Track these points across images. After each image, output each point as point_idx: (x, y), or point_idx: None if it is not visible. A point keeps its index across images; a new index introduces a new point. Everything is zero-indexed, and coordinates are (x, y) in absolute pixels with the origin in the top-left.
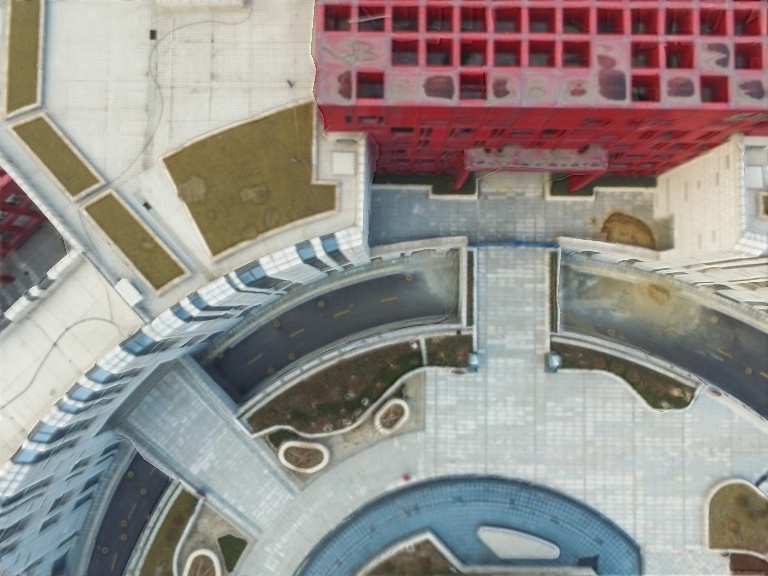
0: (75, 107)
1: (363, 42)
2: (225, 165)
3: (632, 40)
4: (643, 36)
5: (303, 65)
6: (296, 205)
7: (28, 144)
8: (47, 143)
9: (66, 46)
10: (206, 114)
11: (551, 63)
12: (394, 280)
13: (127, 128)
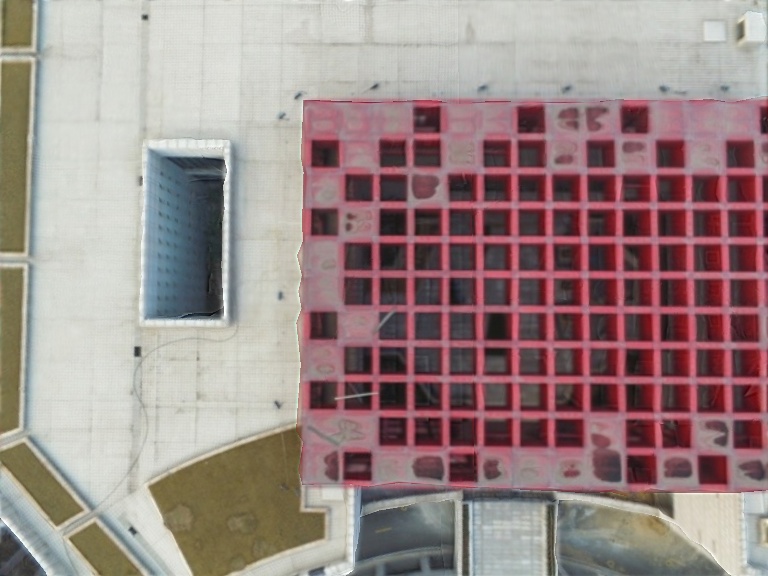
0: (58, 428)
1: (350, 420)
2: (212, 493)
3: (627, 418)
4: (638, 413)
5: (291, 385)
6: (284, 535)
7: (11, 470)
8: (30, 470)
9: (49, 364)
10: (192, 435)
11: (544, 442)
12: (389, 510)
13: (111, 450)
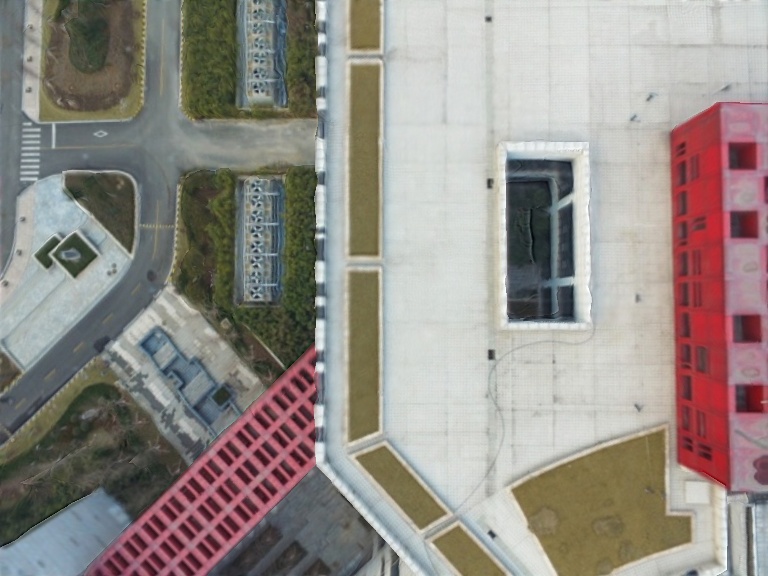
0: (414, 431)
1: None
2: (576, 496)
3: None
4: None
5: (650, 388)
6: (651, 538)
7: (371, 474)
8: (392, 473)
9: (403, 368)
10: (550, 438)
11: None
12: None
13: (469, 453)
